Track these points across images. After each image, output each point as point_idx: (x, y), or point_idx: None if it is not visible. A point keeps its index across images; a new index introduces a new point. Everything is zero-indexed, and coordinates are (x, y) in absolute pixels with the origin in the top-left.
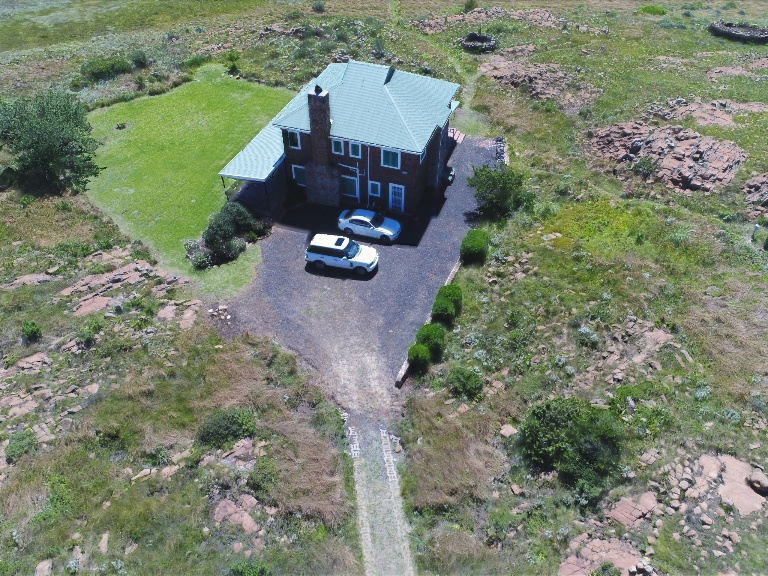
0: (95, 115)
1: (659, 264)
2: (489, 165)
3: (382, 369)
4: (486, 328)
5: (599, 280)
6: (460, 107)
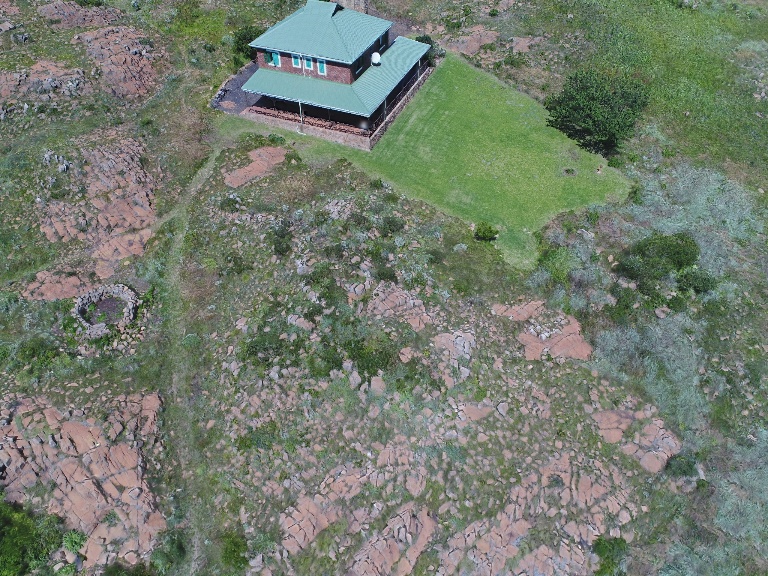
0: (614, 192)
1: (199, 4)
2: (238, 86)
3: (341, 4)
4: (292, 7)
5: (232, 5)
6: (224, 150)
